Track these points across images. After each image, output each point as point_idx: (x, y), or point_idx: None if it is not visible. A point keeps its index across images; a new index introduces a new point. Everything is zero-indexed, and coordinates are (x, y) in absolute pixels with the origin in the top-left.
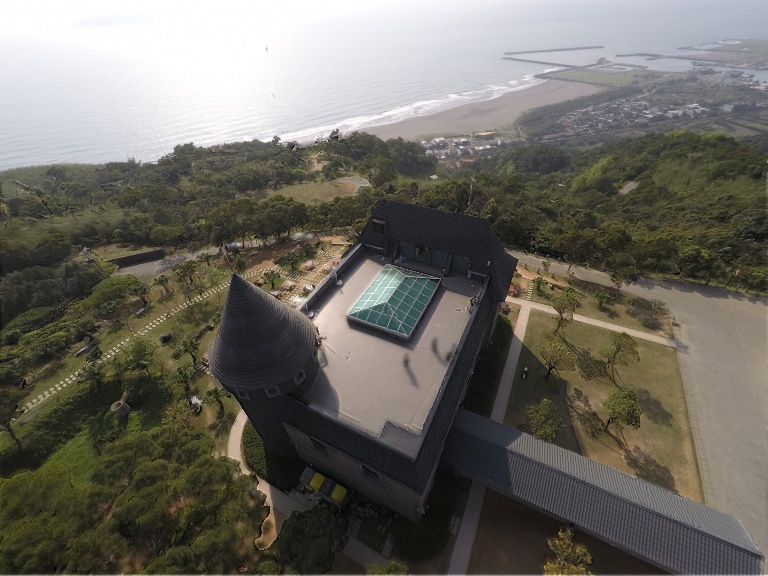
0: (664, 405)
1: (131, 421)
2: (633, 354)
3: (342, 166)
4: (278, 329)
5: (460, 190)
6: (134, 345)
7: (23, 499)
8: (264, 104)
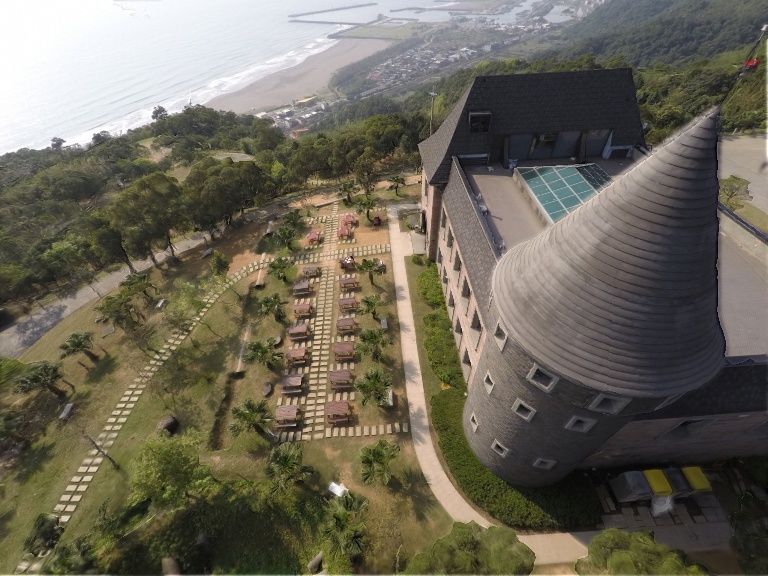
0: None
1: None
2: (745, 194)
3: (197, 145)
4: None
5: (399, 120)
6: (157, 463)
7: None
8: (118, 20)
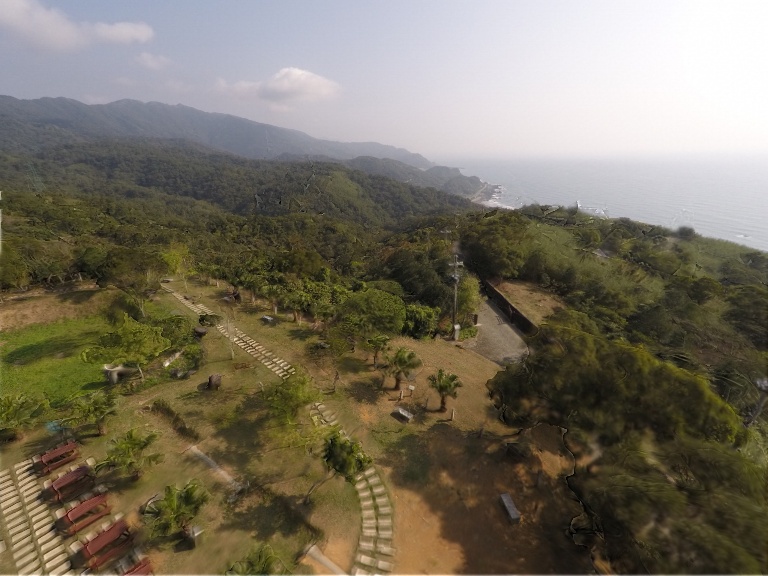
0: None
1: (94, 391)
2: None
3: None
4: None
5: None
6: None
7: None
8: None
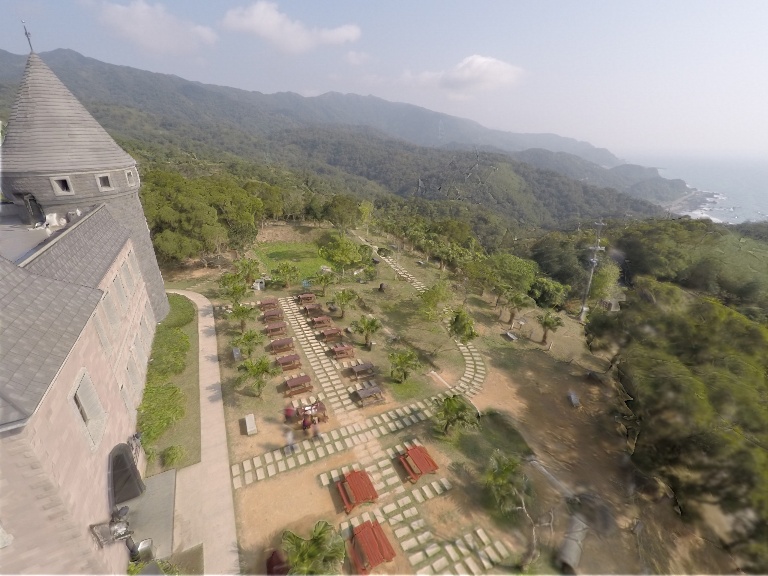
0: None
1: None
2: None
3: None
4: None
5: None
6: None
7: None
8: None
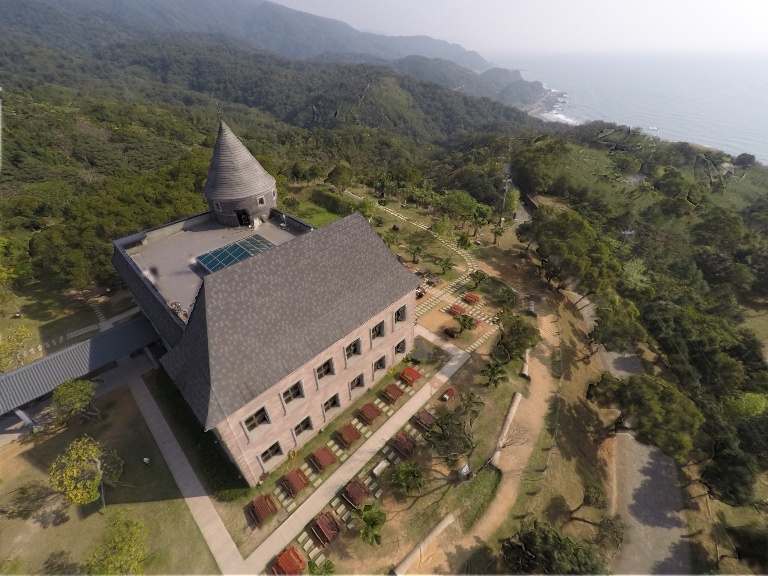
0: None
1: None
2: None
3: None
4: (215, 167)
5: None
6: None
7: None
8: None
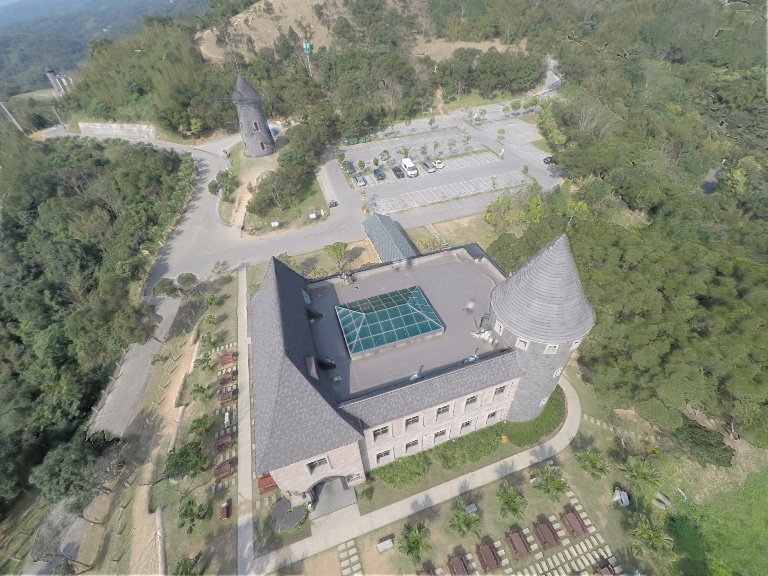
0: (302, 261)
1: None
2: None
3: None
4: None
5: None
6: None
7: (765, 388)
8: None
